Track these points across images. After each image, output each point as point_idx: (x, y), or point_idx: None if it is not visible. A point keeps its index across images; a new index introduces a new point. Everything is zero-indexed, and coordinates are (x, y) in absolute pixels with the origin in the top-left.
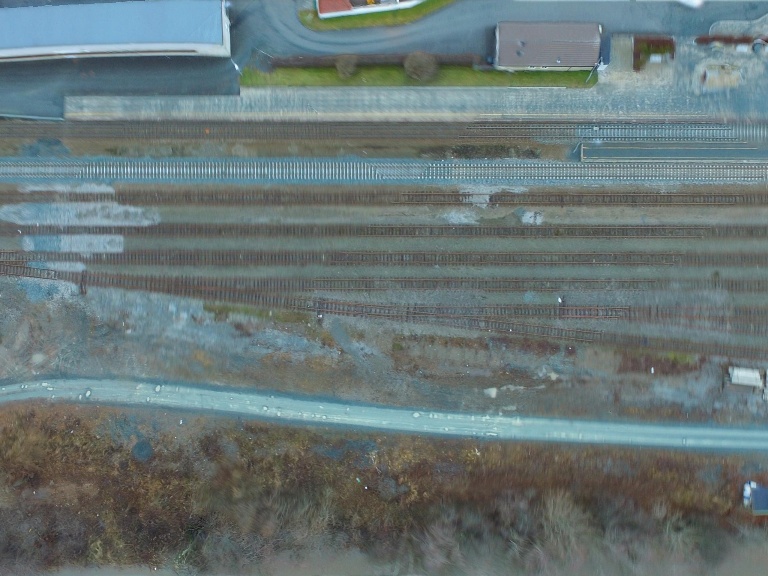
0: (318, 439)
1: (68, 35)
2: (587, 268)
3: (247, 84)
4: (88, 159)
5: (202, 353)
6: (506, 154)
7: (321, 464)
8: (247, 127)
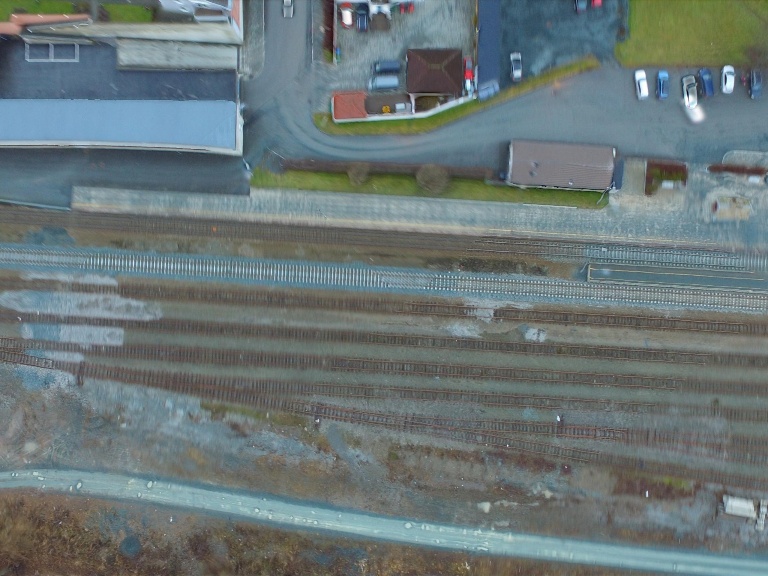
0: (308, 544)
1: (80, 131)
2: (587, 388)
3: (257, 185)
4: (93, 250)
5: (196, 451)
6: (513, 270)
7: (310, 570)
8: (255, 228)
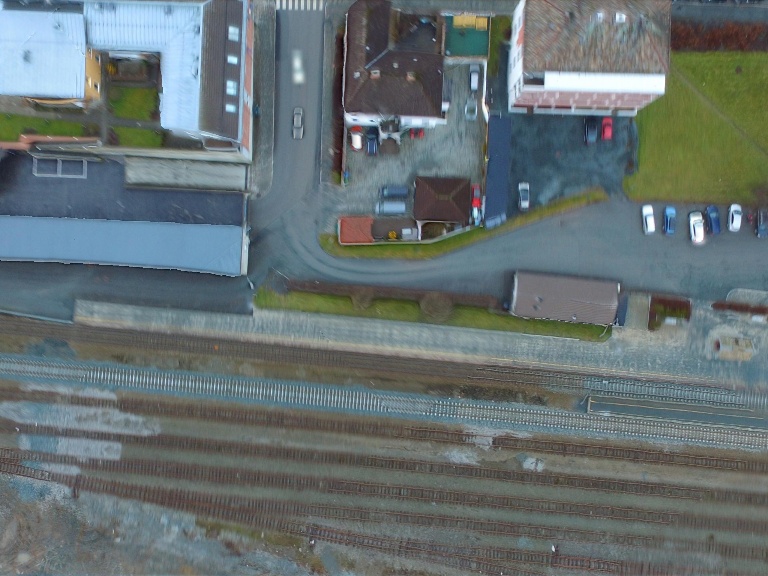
0: None
1: (85, 252)
2: (583, 519)
3: (261, 305)
4: (93, 363)
5: (190, 568)
6: (513, 398)
7: None
8: (257, 347)
